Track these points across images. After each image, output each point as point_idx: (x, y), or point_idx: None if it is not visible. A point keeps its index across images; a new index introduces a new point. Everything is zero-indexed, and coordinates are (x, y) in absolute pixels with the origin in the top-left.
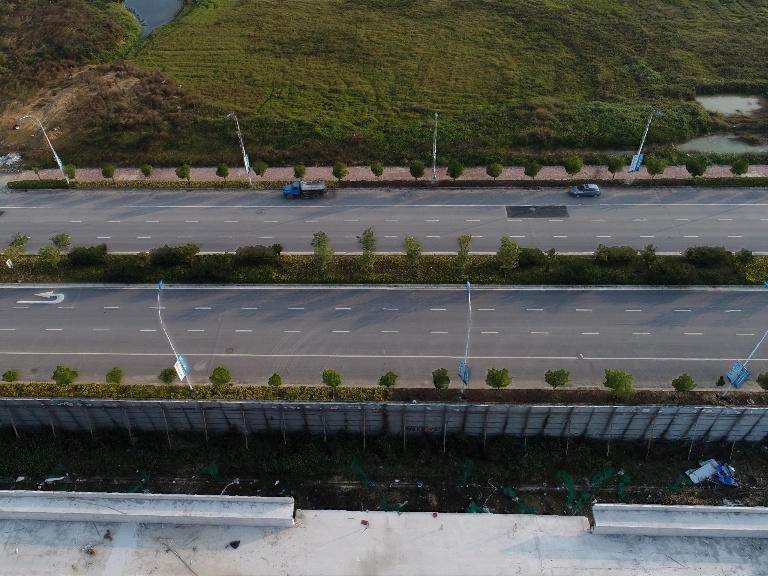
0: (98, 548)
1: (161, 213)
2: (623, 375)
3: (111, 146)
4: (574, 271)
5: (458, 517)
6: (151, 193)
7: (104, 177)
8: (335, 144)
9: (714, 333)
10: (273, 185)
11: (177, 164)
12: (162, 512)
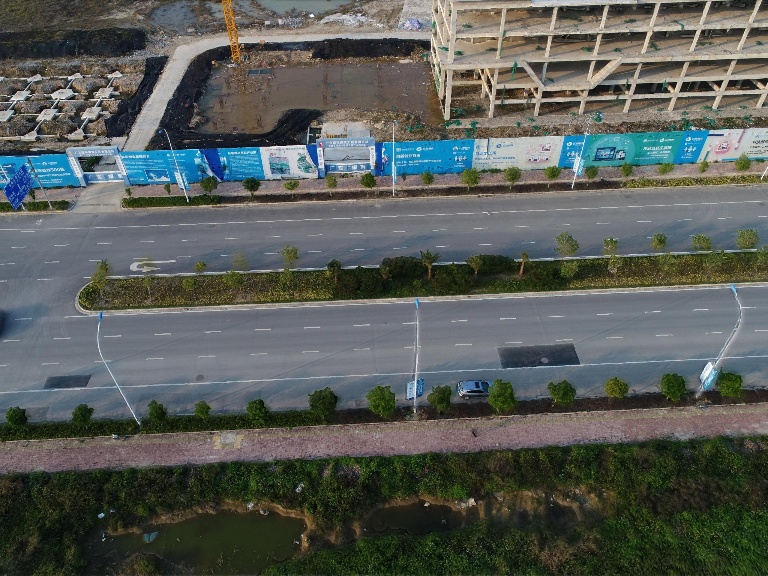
0: None
1: None
2: (470, 171)
3: None
4: (498, 259)
5: (578, 2)
6: None
7: None
8: None
9: (381, 233)
10: None
11: None
12: None
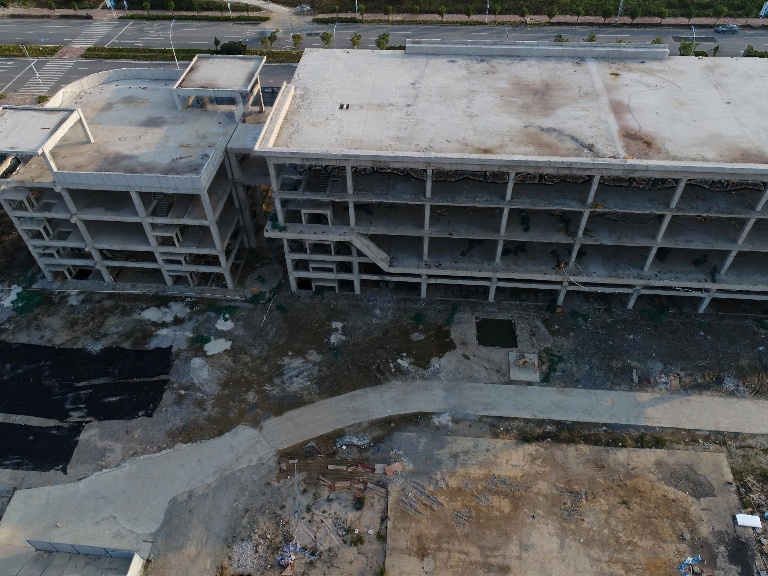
0: (580, 62)
1: (430, 36)
2: None
3: (374, 2)
4: None
5: (743, 58)
6: (417, 26)
7: (384, 14)
8: (537, 3)
9: None
10: (502, 23)
11: (428, 11)
12: (608, 49)
